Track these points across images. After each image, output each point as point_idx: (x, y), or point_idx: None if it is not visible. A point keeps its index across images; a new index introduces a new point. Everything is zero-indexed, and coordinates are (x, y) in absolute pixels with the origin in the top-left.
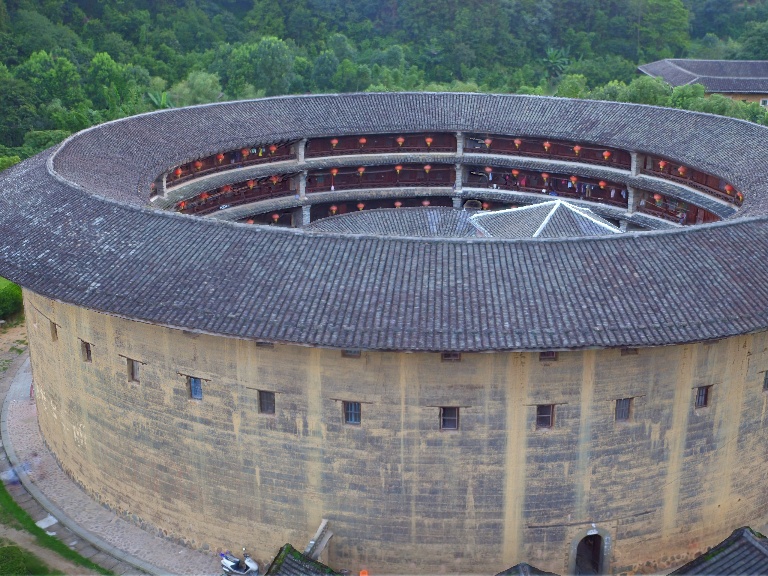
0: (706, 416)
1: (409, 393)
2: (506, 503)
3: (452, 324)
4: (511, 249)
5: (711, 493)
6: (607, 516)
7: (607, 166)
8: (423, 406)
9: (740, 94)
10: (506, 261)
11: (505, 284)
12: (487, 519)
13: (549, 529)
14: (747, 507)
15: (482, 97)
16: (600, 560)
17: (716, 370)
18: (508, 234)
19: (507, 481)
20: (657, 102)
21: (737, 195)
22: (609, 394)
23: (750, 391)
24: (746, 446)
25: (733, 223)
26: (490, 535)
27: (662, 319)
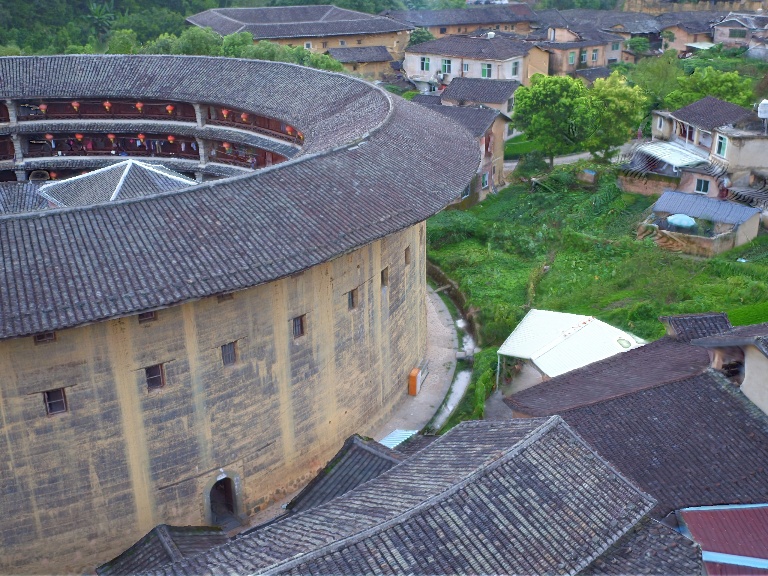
0: (305, 344)
1: (5, 385)
2: (132, 472)
3: (39, 304)
4: (89, 216)
5: (321, 412)
6: (232, 458)
7: (173, 120)
8: (24, 395)
9: (285, 39)
10: (86, 229)
11: (89, 253)
12: (115, 493)
13: (179, 485)
14: (353, 417)
15: (27, 60)
16: (233, 501)
17: (306, 300)
18: (83, 201)
19: (129, 450)
20: (210, 52)
21: (298, 135)
22: (213, 342)
23: (338, 313)
24: (343, 363)
25: (298, 161)
26: (121, 508)
27: (250, 261)
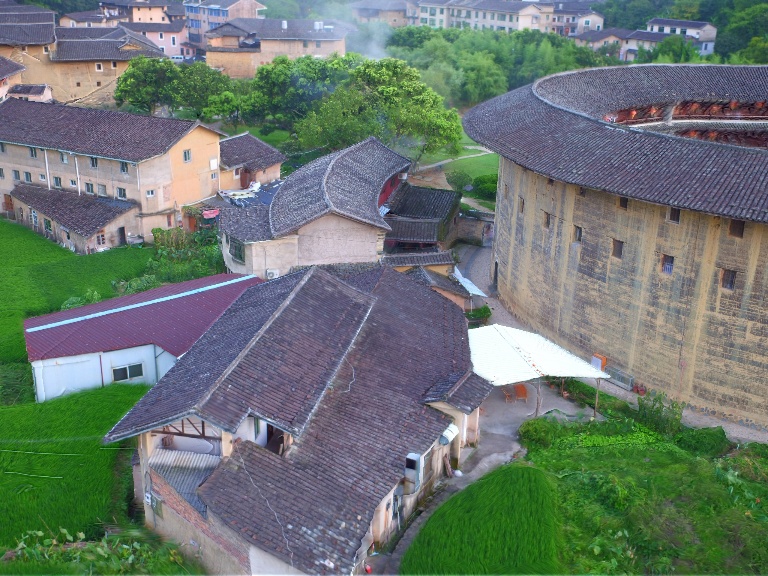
0: None
1: None
2: None
3: None
4: None
5: None
6: None
7: None
8: None
9: None
10: None
11: None
12: None
13: None
14: None
15: None
16: None
17: None
18: None
19: None
20: None
21: None
22: None
23: None
24: None
25: (576, 113)
26: None
27: None
